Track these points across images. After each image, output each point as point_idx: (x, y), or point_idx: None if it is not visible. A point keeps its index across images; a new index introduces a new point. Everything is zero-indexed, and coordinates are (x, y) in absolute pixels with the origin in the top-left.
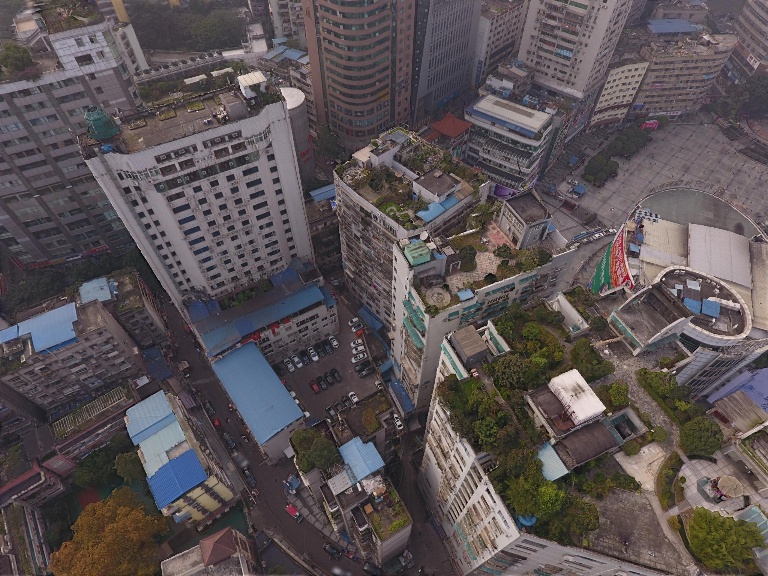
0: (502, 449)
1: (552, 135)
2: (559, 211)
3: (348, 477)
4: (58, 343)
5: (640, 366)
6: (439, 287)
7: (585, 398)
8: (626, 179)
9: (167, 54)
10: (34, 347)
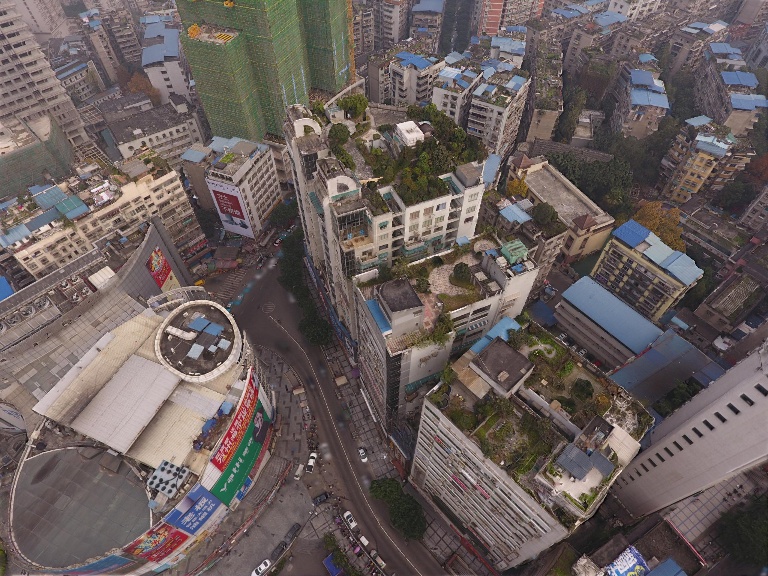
0: None
1: None
2: None
3: (521, 206)
4: None
5: None
6: None
7: (407, 128)
8: None
9: None
10: None
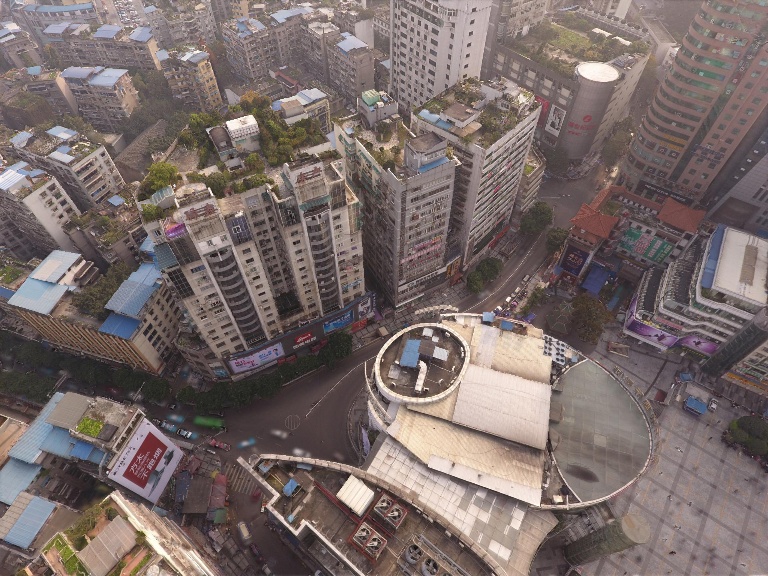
0: (225, 115)
1: (746, 328)
2: (648, 386)
3: None
4: (342, 48)
5: (277, 182)
6: (361, 127)
7: (238, 124)
8: None
9: (660, 28)
10: (339, 43)
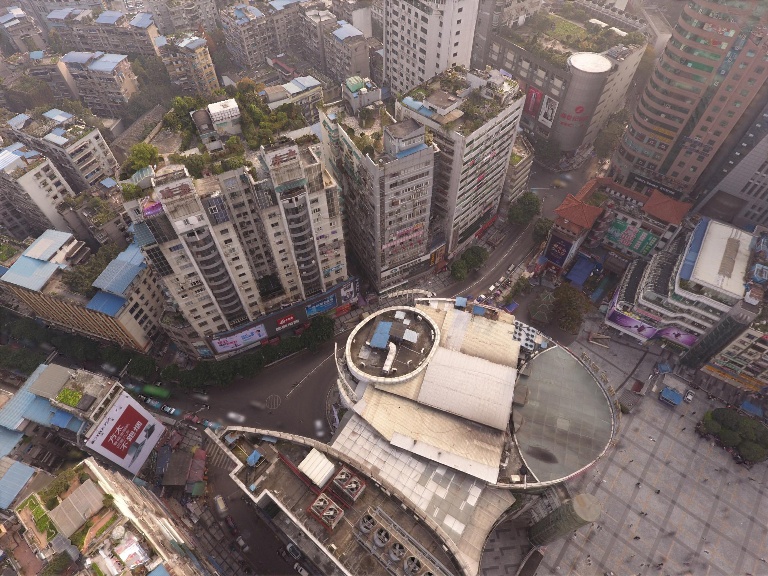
0: (210, 99)
1: (723, 321)
2: (626, 376)
3: None
4: (338, 36)
5: (255, 165)
6: (345, 113)
7: (219, 108)
8: (740, 479)
9: (661, 19)
10: (335, 31)
